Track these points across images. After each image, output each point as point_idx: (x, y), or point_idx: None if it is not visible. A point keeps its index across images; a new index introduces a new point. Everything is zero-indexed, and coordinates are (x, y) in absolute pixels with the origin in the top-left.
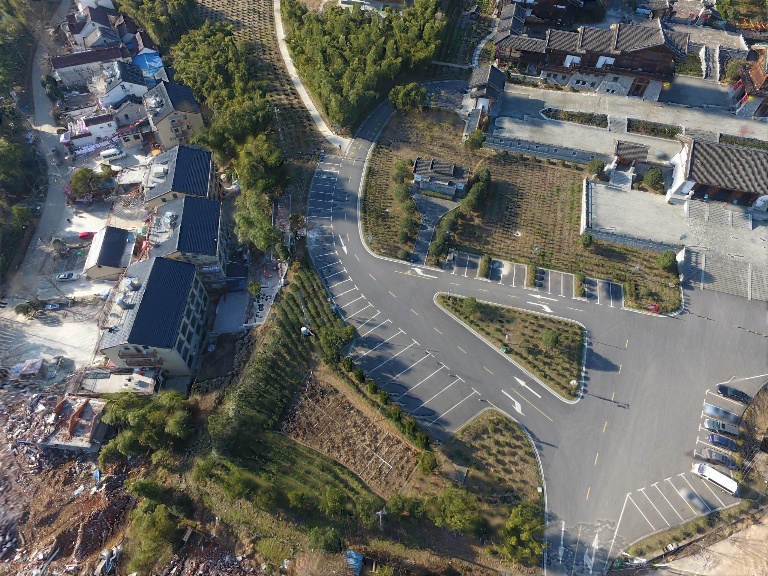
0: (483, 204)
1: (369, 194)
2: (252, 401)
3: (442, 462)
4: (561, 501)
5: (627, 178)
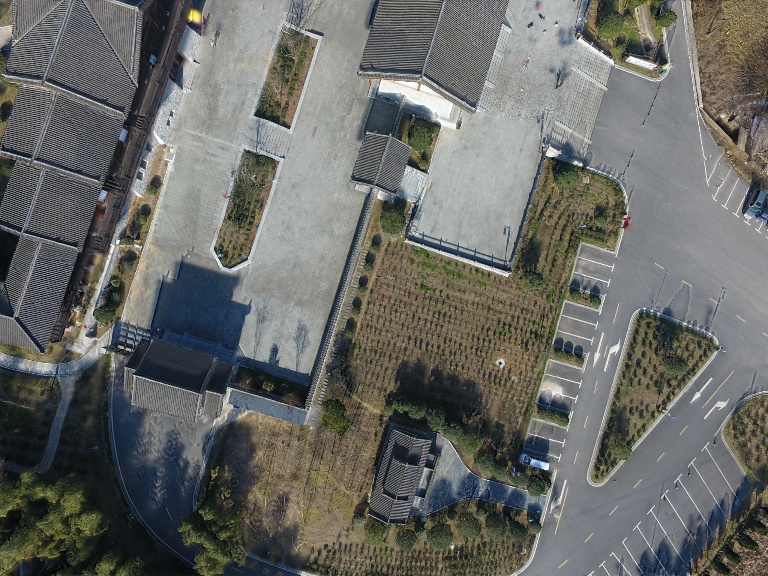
0: None
1: None
2: None
3: None
4: None
5: (409, 174)
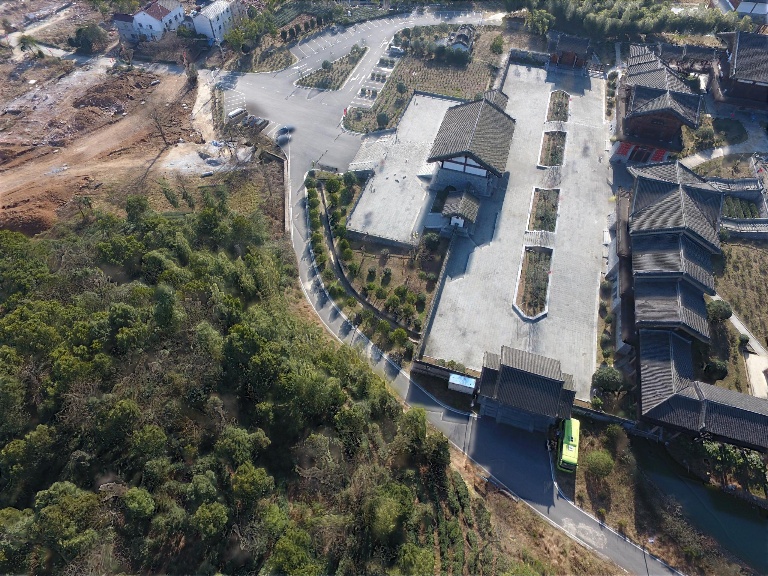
0: (440, 59)
1: None
2: (317, 6)
3: (276, 46)
4: (249, 77)
5: None
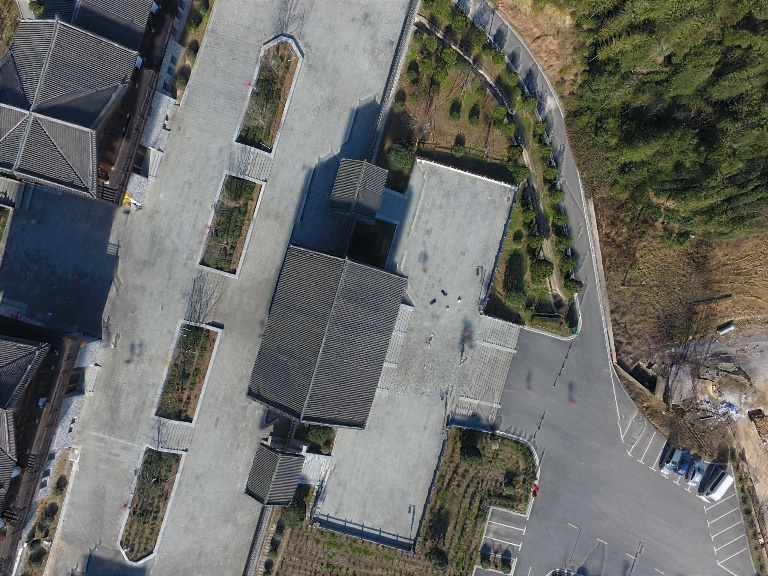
0: None
1: None
2: None
3: None
4: None
5: (311, 461)
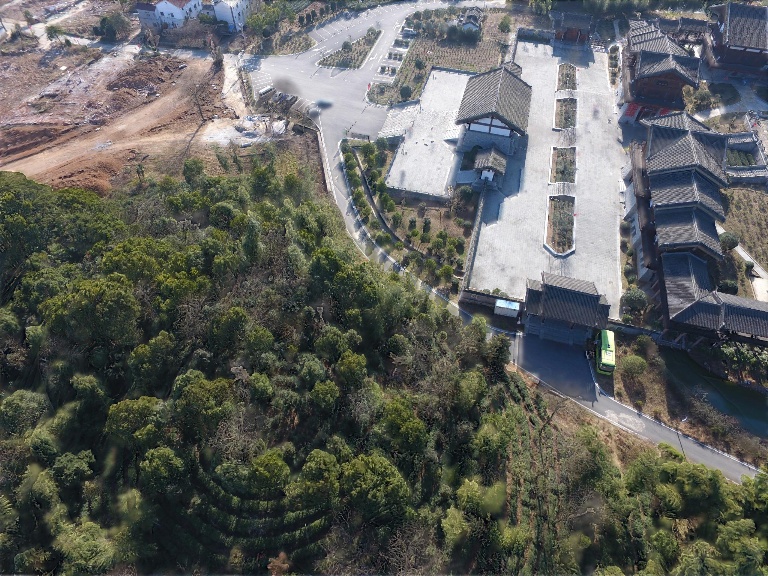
0: (451, 39)
1: None
2: None
3: (295, 31)
4: (272, 59)
5: None
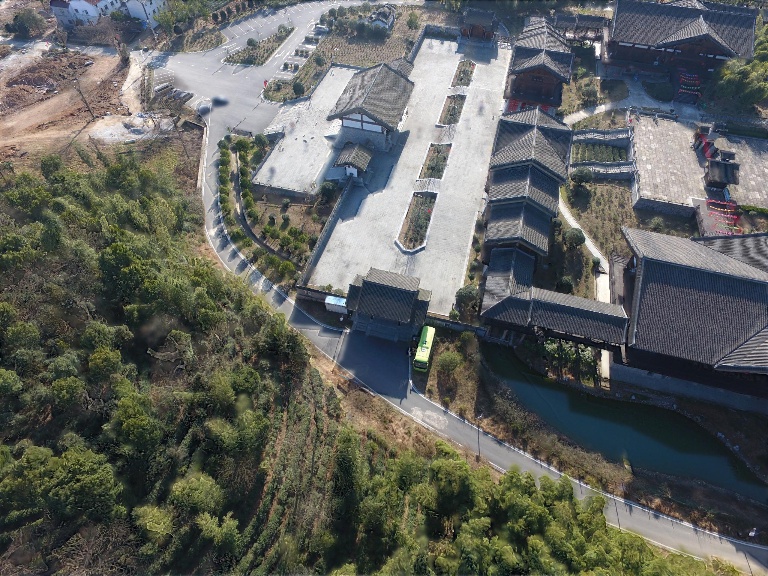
0: (361, 36)
1: (372, 6)
2: None
3: (208, 28)
4: (180, 56)
5: None
